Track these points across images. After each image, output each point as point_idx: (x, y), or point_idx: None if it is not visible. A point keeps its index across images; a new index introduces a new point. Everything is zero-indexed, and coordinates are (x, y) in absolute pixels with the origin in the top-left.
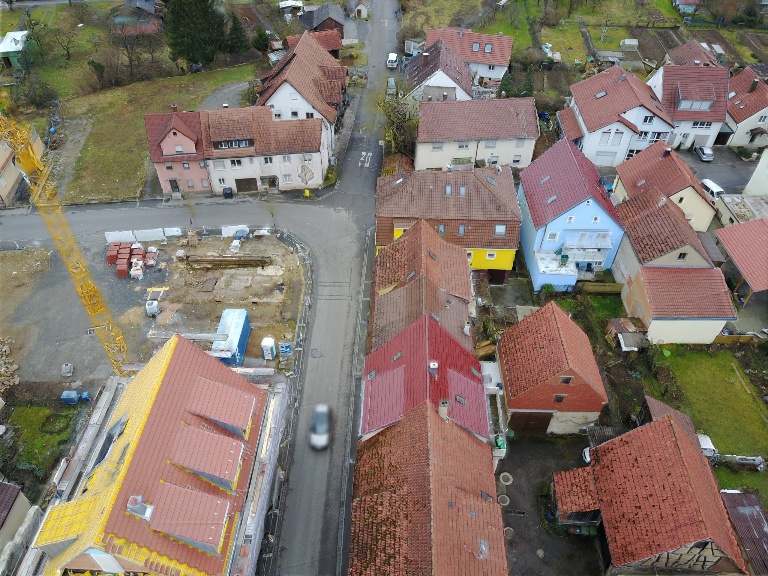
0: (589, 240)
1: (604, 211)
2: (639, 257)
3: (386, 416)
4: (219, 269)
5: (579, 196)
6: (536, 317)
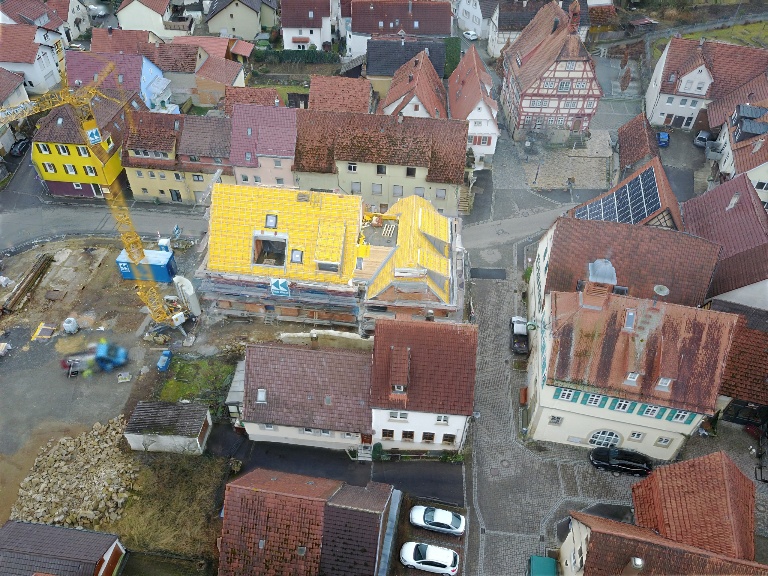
0: (160, 85)
1: (151, 62)
2: (188, 71)
3: (290, 139)
4: (35, 290)
5: (136, 61)
6: (230, 99)
